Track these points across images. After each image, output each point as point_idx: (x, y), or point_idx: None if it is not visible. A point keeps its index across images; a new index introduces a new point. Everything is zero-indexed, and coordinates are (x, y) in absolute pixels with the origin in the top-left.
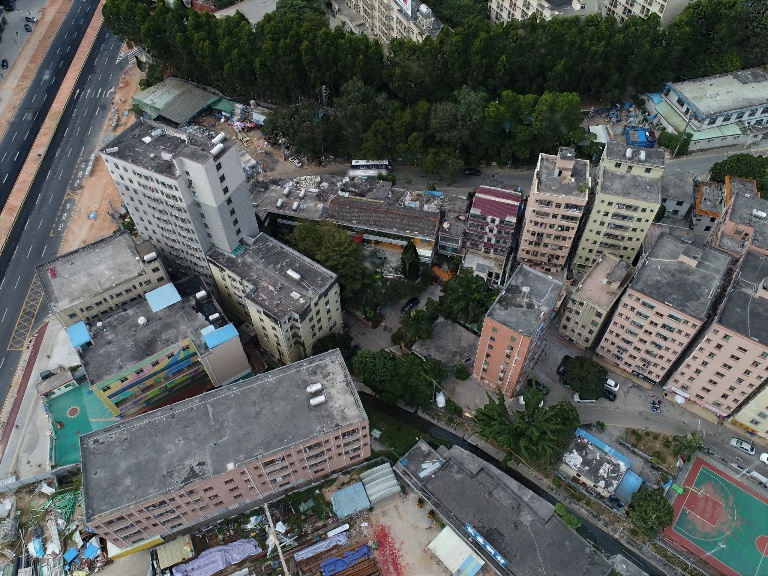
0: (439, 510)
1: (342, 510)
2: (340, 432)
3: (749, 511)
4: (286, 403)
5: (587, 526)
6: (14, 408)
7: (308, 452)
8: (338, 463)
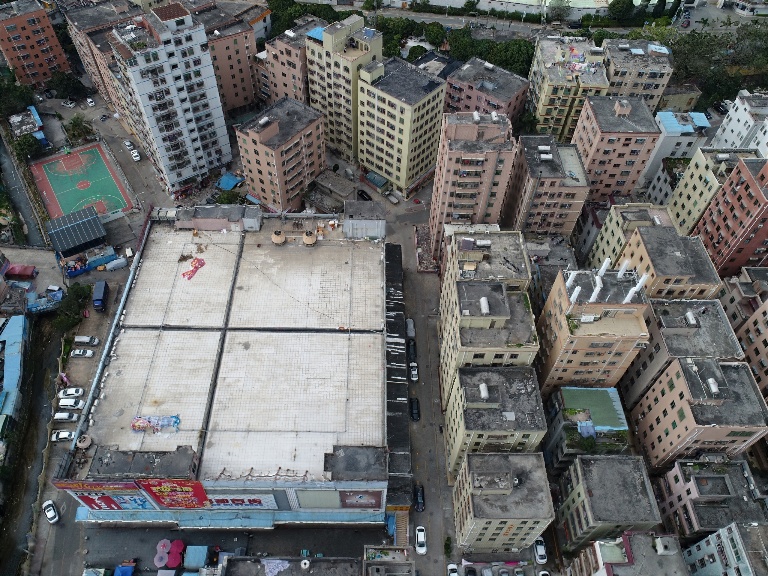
0: None
1: None
2: None
3: (95, 170)
4: None
5: (6, 158)
6: None
7: None
8: None
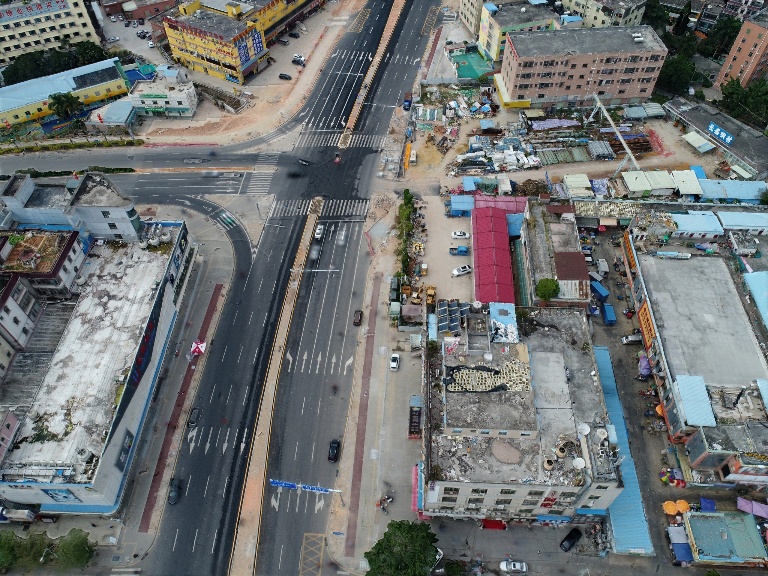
0: (691, 123)
1: (631, 114)
2: (651, 53)
3: None
4: (619, 40)
5: None
6: (430, 56)
7: (629, 63)
8: (633, 91)
